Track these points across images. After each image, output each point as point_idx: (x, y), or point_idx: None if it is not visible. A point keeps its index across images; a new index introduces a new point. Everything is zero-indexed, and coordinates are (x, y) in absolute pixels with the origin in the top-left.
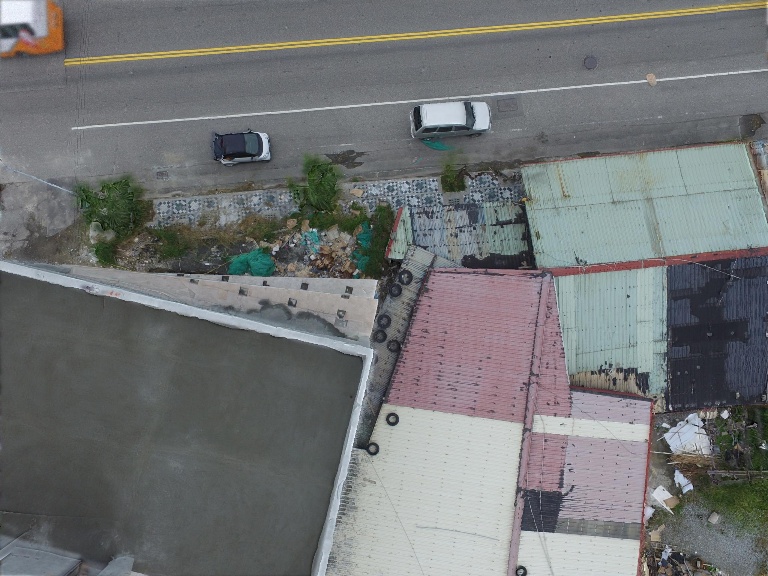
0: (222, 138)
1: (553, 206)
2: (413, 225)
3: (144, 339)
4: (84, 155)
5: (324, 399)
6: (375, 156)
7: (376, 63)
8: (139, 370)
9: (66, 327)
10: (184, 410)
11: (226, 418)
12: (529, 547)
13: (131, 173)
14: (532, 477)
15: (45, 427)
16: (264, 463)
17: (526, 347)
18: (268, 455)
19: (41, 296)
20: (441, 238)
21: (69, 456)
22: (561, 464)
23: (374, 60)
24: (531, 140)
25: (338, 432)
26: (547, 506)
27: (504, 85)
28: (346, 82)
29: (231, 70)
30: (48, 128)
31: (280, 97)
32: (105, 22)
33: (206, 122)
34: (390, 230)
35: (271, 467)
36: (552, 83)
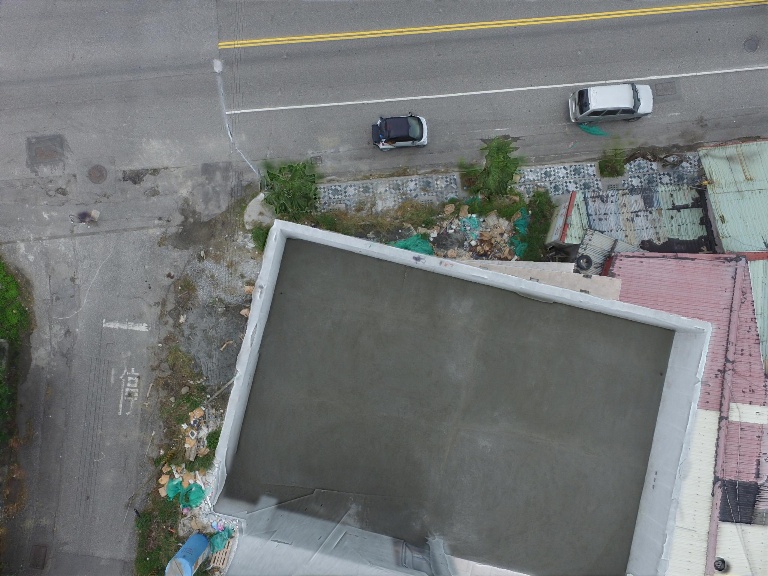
0: (386, 121)
1: (736, 190)
2: (588, 209)
3: (447, 313)
4: (239, 140)
5: (634, 376)
6: (531, 141)
7: (532, 46)
8: (443, 345)
9: (366, 301)
10: (491, 387)
11: (534, 395)
12: (726, 538)
13: (285, 158)
14: (729, 466)
15: (348, 404)
16: (573, 442)
17: (720, 333)
18: (577, 434)
19: (339, 269)
20: (617, 223)
21: (374, 434)
22: (757, 453)
23: (530, 43)
24: (690, 124)
25: (649, 411)
26: (744, 496)
27: (662, 68)
28: (502, 66)
29: (385, 54)
30: (202, 112)
31: (435, 81)
32: (258, 5)
33: (360, 106)
34: (549, 216)
35: (580, 446)
36: (711, 66)
